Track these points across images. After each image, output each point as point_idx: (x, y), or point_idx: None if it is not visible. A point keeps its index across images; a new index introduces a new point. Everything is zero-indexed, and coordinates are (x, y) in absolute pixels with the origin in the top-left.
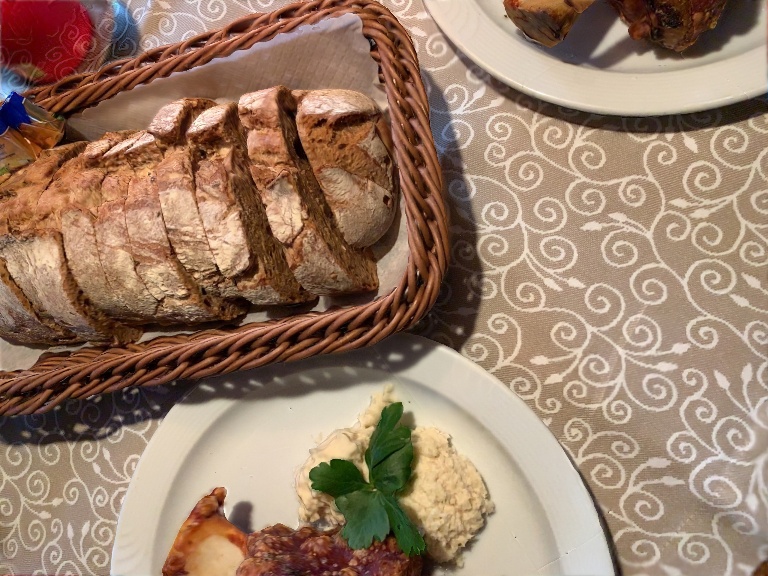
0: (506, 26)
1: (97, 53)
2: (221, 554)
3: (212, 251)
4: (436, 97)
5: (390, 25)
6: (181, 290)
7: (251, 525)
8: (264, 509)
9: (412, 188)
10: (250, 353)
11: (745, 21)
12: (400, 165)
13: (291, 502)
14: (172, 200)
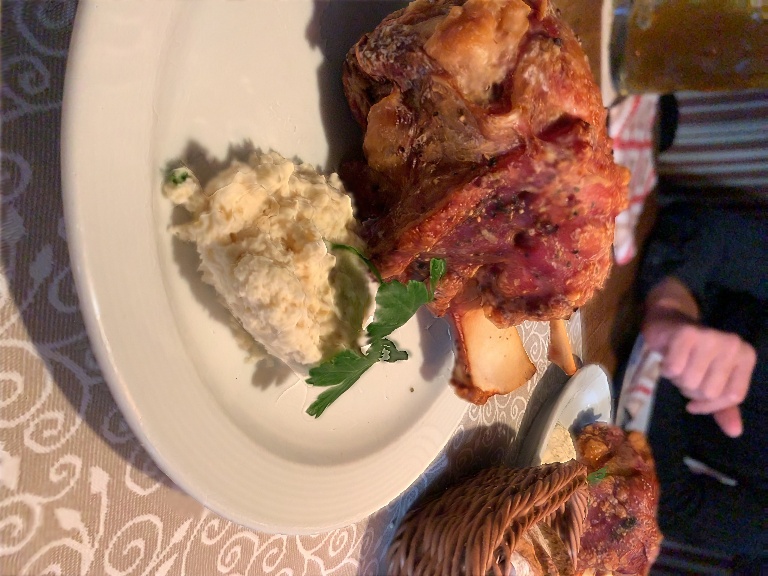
0: (426, 393)
1: None
2: None
3: None
4: None
5: None
6: None
7: None
8: None
9: None
10: None
11: None
12: None
13: None
14: None
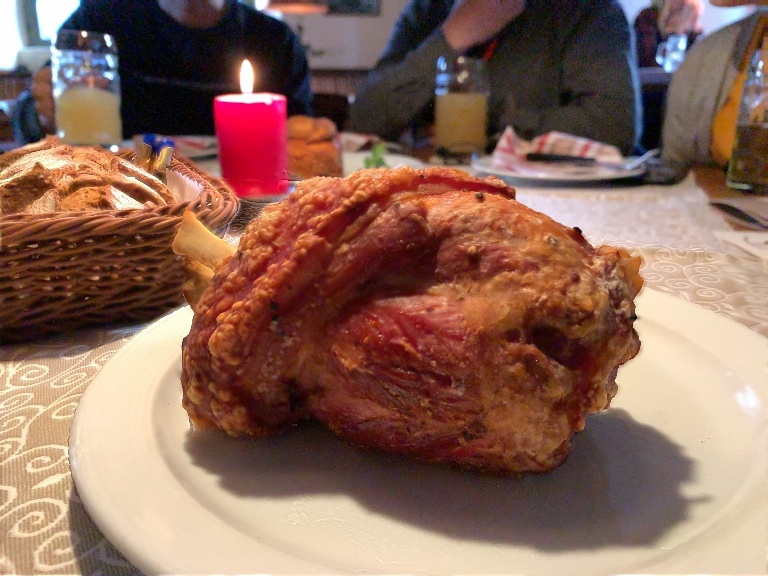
0: None
1: None
2: None
3: None
4: None
5: None
6: None
7: None
8: None
9: (7, 216)
10: None
11: (245, 485)
12: None
13: None
14: None
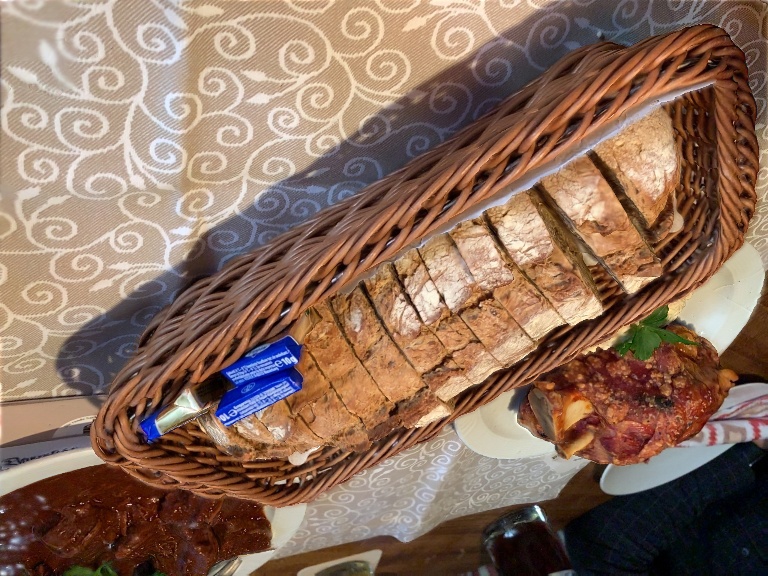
0: None
1: (120, 131)
2: (575, 410)
3: None
4: (660, 8)
5: (731, 58)
6: None
7: None
8: None
9: (740, 205)
10: None
11: None
12: (731, 192)
13: None
14: None
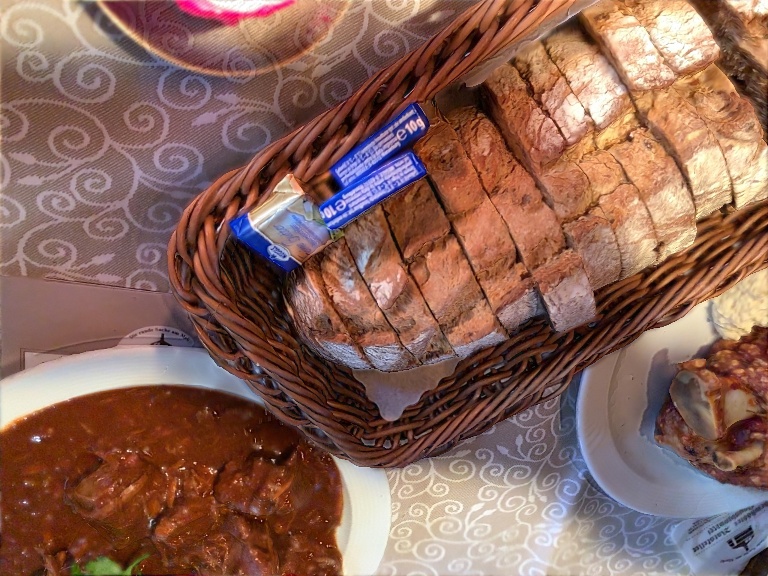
0: None
1: None
2: (735, 401)
3: (737, 195)
4: None
5: None
6: (690, 242)
7: (670, 361)
8: (678, 346)
9: None
10: (759, 262)
11: None
12: None
13: (702, 331)
14: (700, 164)
